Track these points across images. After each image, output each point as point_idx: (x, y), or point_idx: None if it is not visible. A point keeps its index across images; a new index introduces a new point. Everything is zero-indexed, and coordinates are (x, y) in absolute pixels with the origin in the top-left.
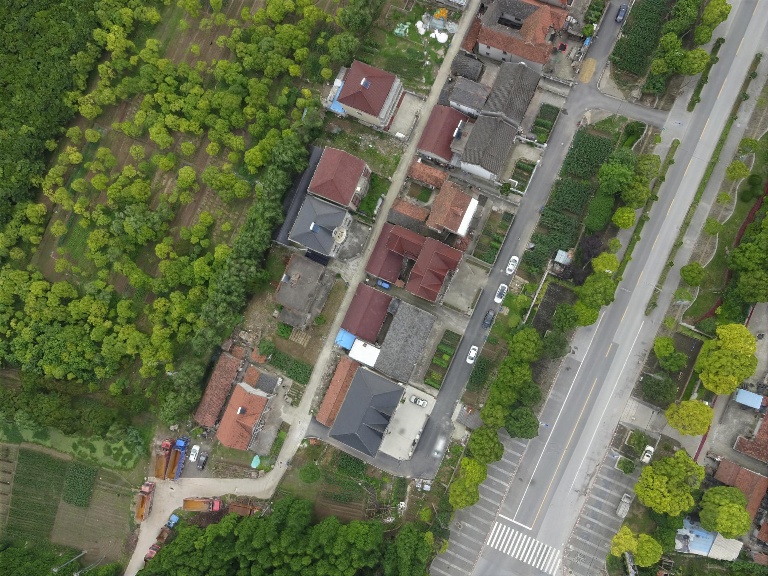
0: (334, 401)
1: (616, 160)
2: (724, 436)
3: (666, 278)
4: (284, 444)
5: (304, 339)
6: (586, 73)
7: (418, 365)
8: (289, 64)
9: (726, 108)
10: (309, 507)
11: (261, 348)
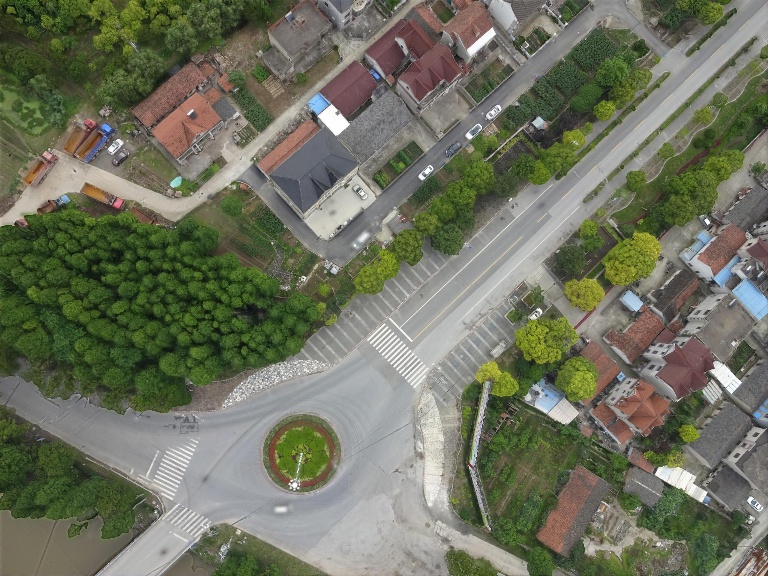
0: (283, 154)
1: (621, 56)
2: (600, 326)
3: (612, 179)
4: (213, 177)
5: (276, 90)
6: None
7: (374, 161)
8: None
9: (713, 68)
10: (217, 238)
11: (233, 74)
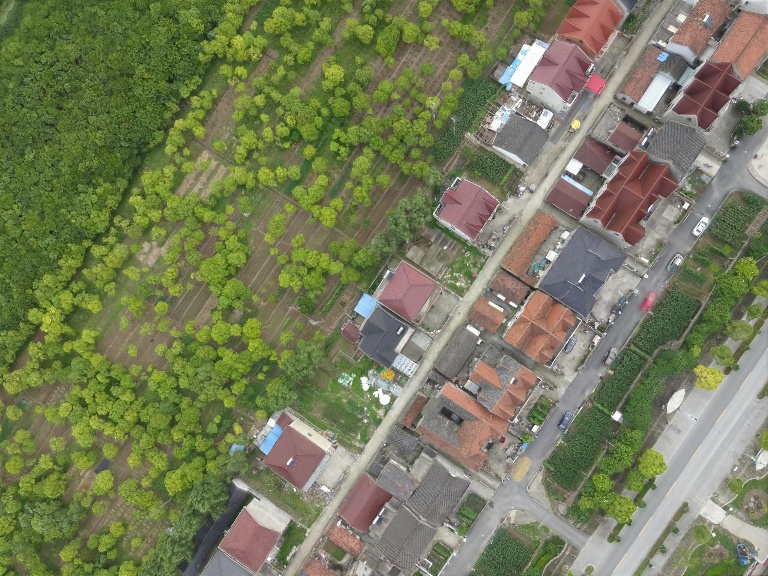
0: None
1: None
2: None
3: None
4: None
5: None
6: (519, 471)
7: None
8: (224, 397)
9: (645, 547)
10: None
11: None
